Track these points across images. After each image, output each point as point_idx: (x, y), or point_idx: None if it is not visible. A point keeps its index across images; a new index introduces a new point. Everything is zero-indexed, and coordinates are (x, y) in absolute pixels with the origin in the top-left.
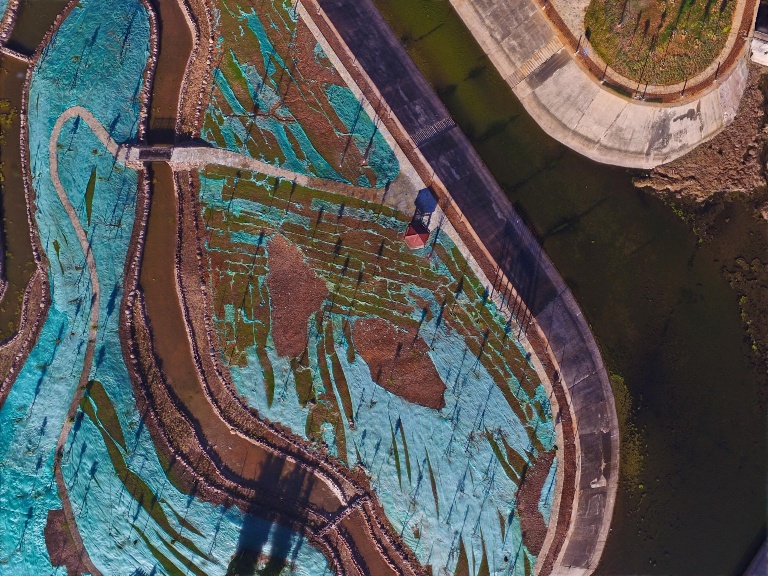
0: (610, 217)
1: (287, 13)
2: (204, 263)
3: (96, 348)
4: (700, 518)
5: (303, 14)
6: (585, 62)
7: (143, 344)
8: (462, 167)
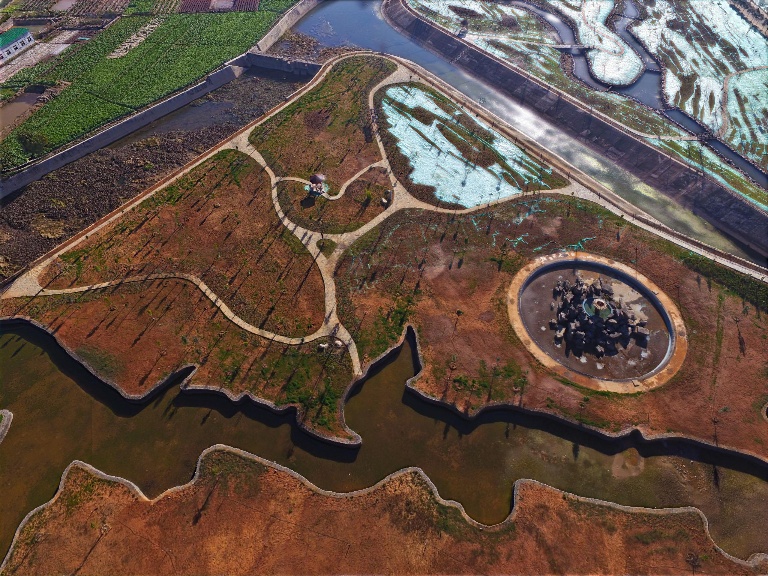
0: None
1: None
2: None
3: None
4: (353, 0)
5: None
6: None
7: None
8: None
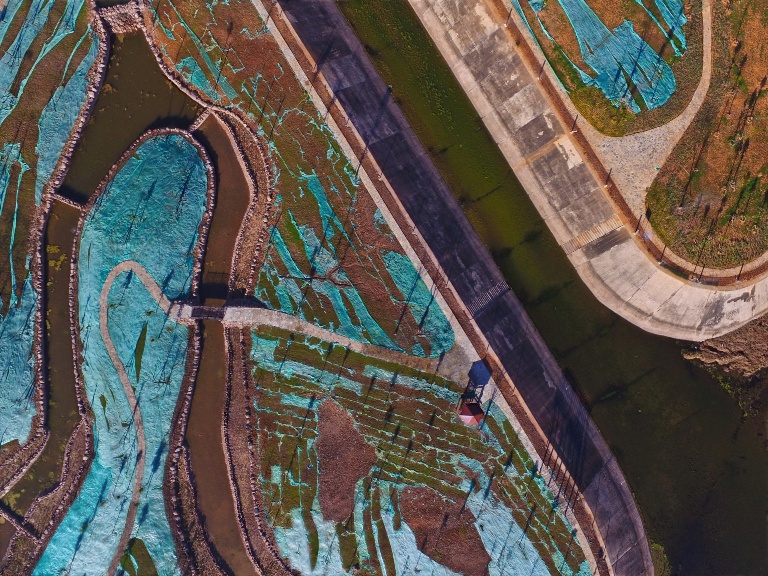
0: (658, 387)
1: (348, 177)
2: (252, 422)
3: (139, 506)
4: None
5: (364, 179)
6: (644, 242)
7: (186, 501)
8: (515, 335)
